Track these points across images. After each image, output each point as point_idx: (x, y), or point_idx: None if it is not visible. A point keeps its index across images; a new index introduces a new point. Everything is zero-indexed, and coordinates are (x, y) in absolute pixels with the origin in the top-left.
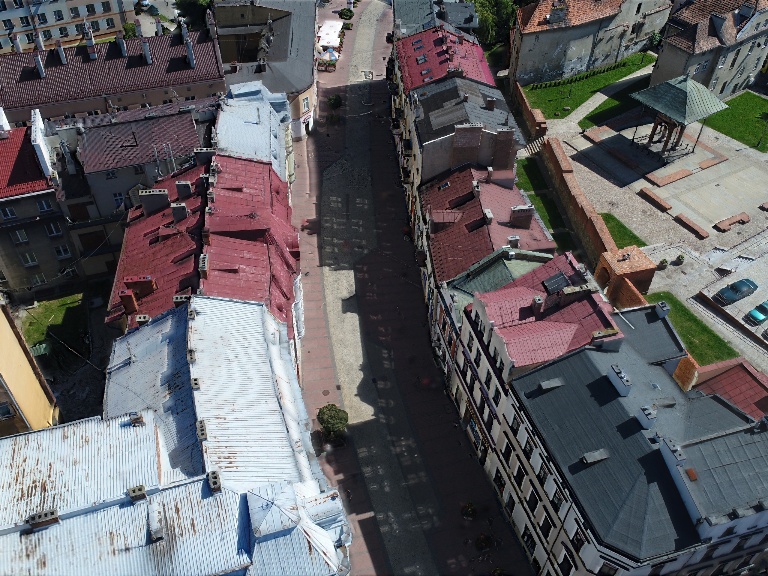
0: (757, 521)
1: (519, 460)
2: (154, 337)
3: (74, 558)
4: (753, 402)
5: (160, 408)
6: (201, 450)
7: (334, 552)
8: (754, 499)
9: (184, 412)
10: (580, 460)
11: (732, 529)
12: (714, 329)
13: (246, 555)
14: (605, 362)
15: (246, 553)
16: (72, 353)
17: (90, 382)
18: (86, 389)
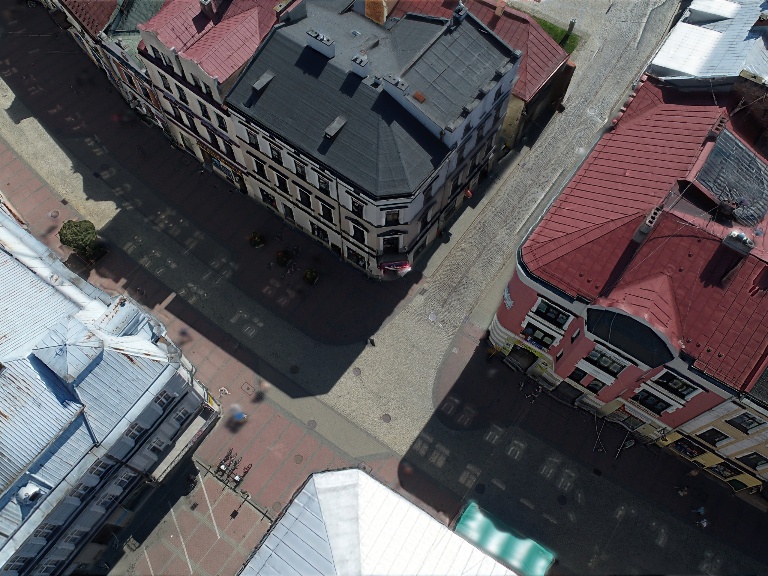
0: (484, 108)
1: (274, 170)
2: None
3: None
4: (440, 5)
5: None
6: None
7: (155, 348)
8: (475, 90)
9: None
10: (324, 138)
11: (469, 126)
12: None
13: (73, 403)
14: (300, 33)
15: (72, 402)
16: None
17: None
18: None
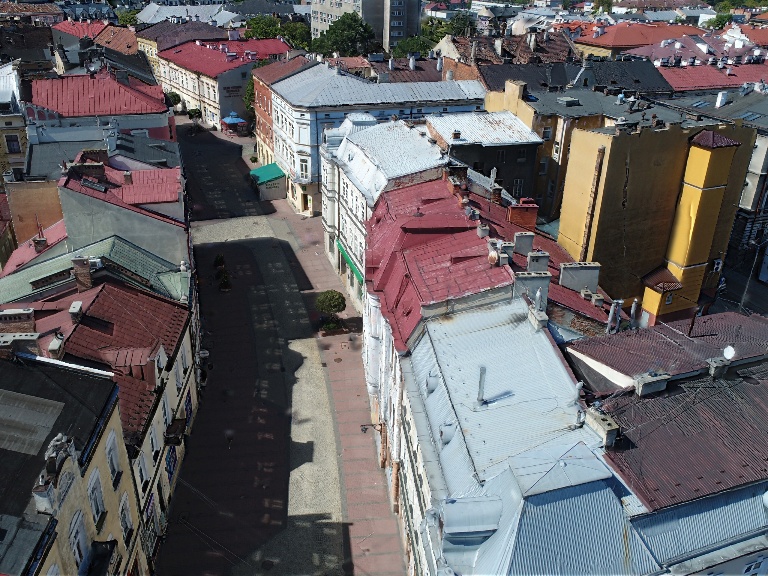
0: None
1: None
2: None
3: None
4: None
5: None
6: None
7: None
8: None
9: None
10: None
11: None
12: None
13: None
14: None
15: None
16: None
17: None
18: None
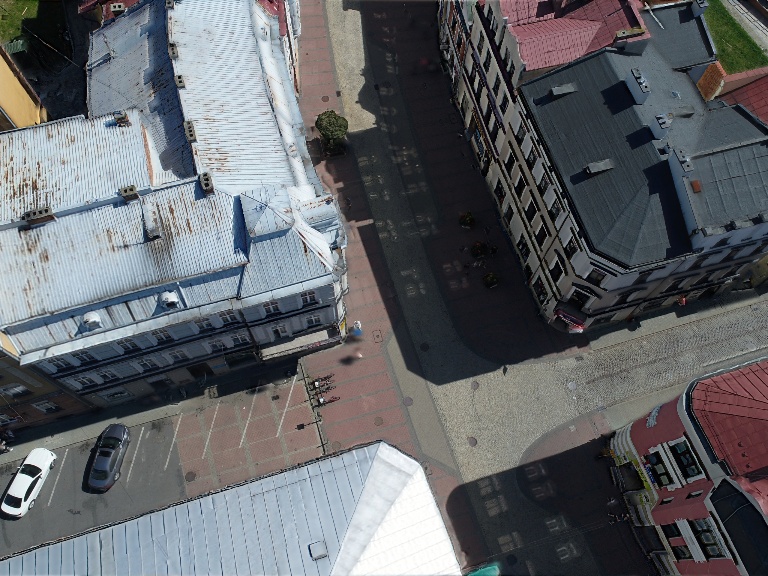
0: (753, 233)
1: (521, 170)
2: (132, 30)
3: (75, 253)
4: None
5: (146, 108)
6: (191, 152)
7: (330, 253)
8: (755, 212)
9: (171, 112)
10: (583, 170)
11: (726, 240)
12: (752, 35)
13: (243, 254)
14: (625, 66)
15: (243, 252)
16: (53, 51)
17: (76, 83)
18: (73, 91)
